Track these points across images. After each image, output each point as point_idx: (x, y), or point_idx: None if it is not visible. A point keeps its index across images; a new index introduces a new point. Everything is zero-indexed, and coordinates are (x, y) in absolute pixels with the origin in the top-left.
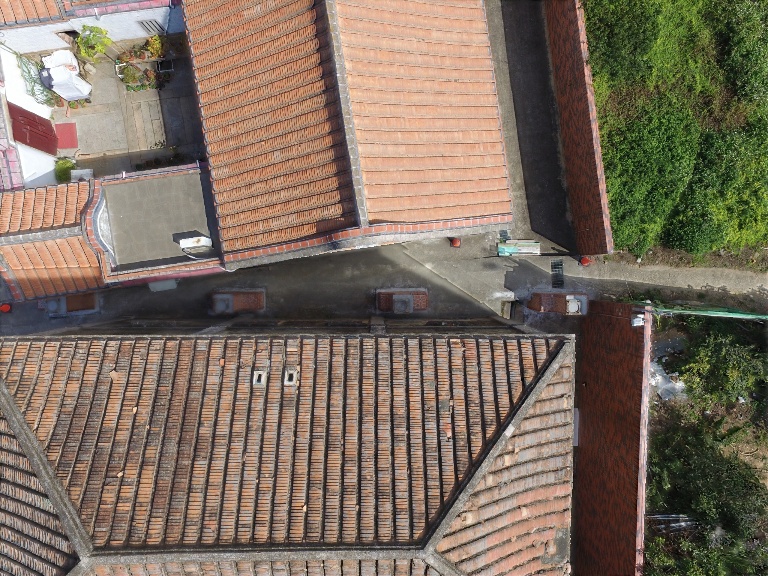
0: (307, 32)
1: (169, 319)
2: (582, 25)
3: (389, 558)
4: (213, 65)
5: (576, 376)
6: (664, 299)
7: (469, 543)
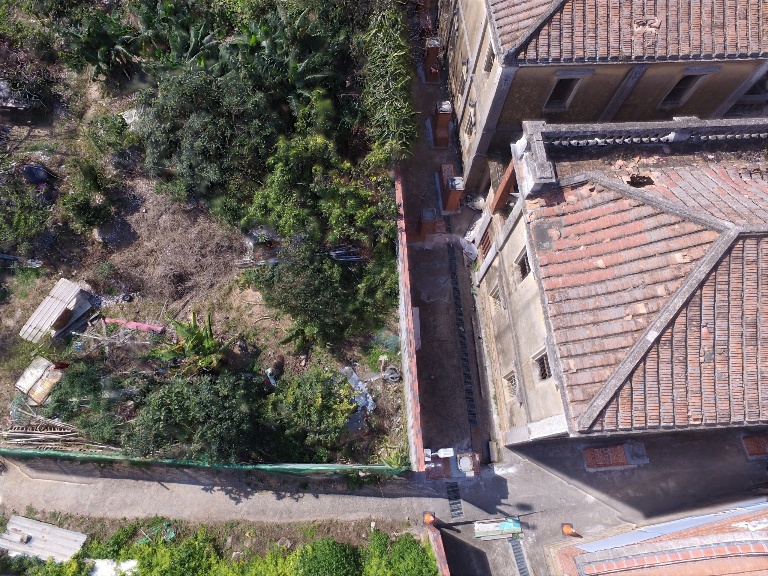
0: None
1: None
2: None
3: (764, 225)
4: None
5: None
6: (344, 478)
7: (671, 238)
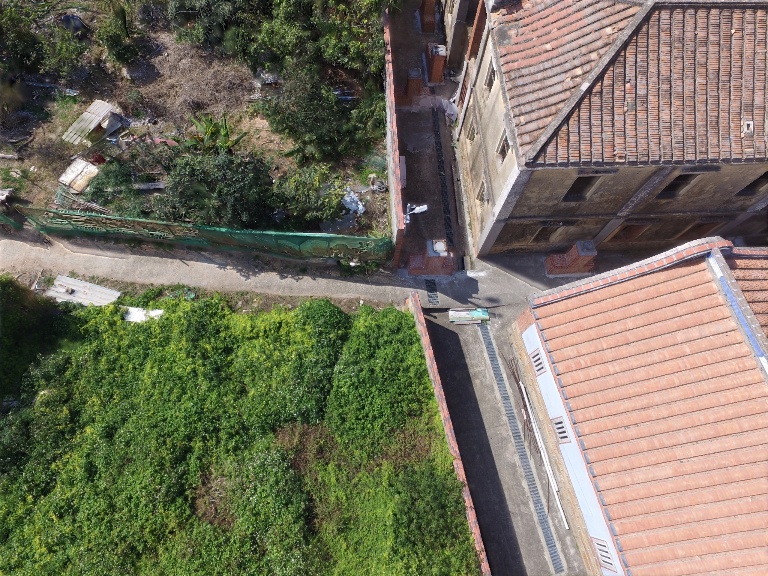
0: None
1: (764, 242)
2: (475, 530)
3: None
4: None
5: None
6: (338, 267)
7: (604, 18)
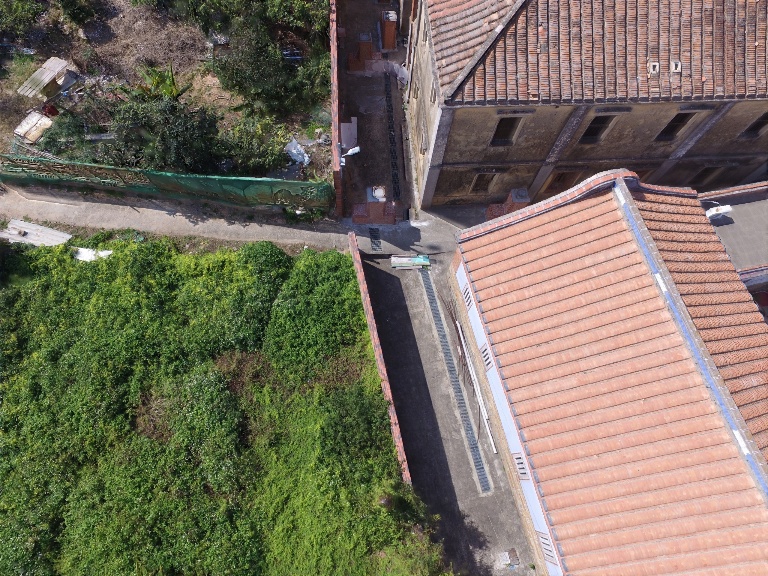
0: (709, 348)
1: None
2: (399, 443)
3: None
4: (766, 342)
5: (345, 171)
6: (284, 215)
7: None
